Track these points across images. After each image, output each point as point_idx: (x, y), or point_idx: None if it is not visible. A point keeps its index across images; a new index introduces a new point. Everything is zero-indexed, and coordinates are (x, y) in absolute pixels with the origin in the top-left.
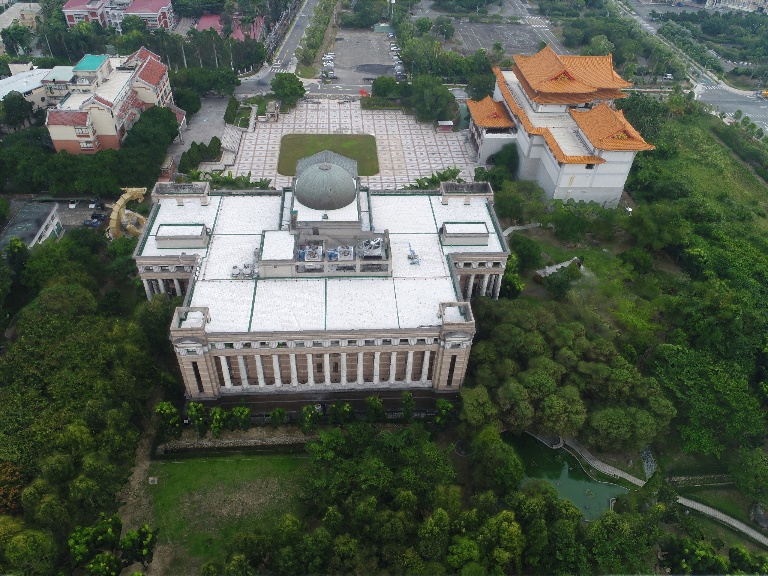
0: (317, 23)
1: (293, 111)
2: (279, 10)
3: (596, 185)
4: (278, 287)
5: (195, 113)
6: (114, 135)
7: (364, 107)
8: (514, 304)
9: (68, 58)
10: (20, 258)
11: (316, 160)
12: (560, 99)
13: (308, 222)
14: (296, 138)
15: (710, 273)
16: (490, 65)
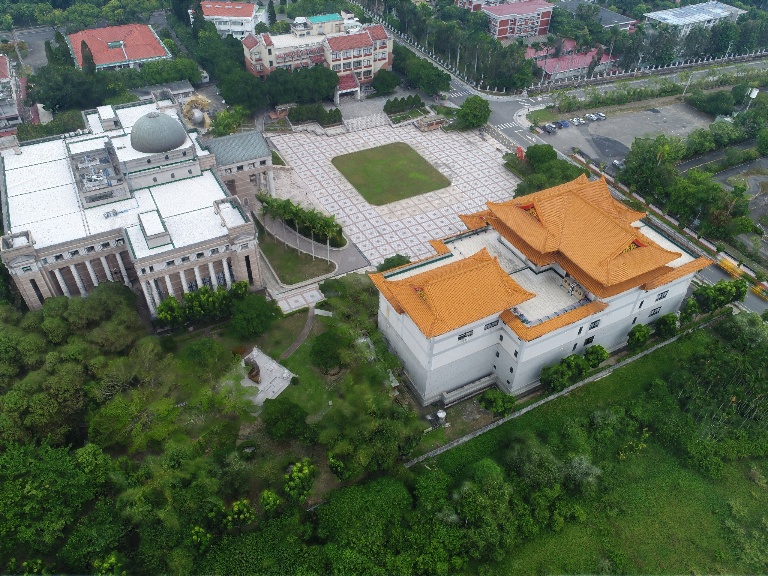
0: (655, 85)
1: (453, 133)
2: (629, 57)
3: (406, 341)
4: (61, 167)
5: (391, 95)
6: (267, 68)
7: (506, 164)
8: (121, 309)
9: (406, 26)
10: (111, 95)
11: (246, 133)
12: (515, 238)
13: (111, 143)
14: (402, 148)
15: (264, 494)
16: (710, 209)
